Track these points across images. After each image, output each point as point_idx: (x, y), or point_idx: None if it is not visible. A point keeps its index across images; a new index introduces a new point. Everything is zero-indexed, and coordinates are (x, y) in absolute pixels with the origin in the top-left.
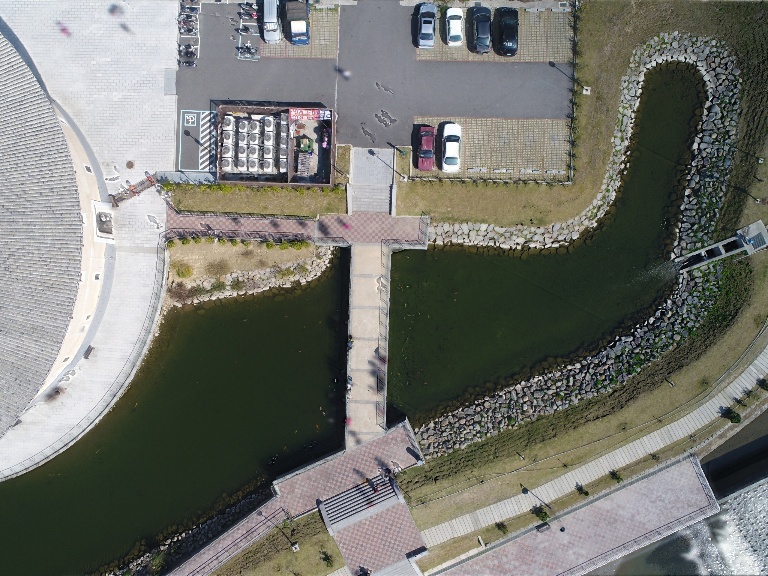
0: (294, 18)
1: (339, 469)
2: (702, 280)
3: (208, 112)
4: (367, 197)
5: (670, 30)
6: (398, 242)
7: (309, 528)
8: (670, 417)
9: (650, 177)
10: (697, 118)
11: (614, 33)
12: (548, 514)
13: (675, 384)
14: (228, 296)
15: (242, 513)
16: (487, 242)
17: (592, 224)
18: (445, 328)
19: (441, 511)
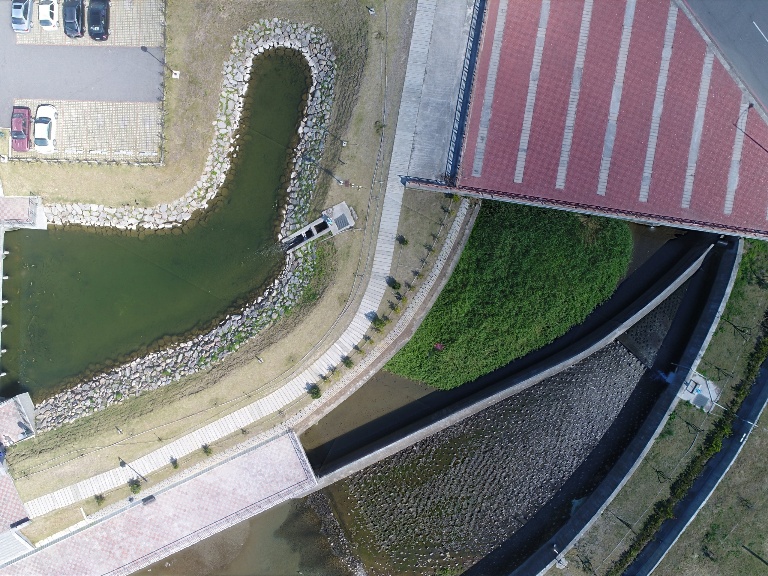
0: None
1: None
2: (302, 260)
3: None
4: None
5: (269, 17)
6: (9, 221)
7: None
8: (259, 393)
9: (263, 160)
10: (303, 103)
11: (206, 19)
12: (145, 487)
13: (264, 361)
14: None
15: None
16: (103, 222)
17: (202, 205)
18: (69, 306)
19: (43, 483)
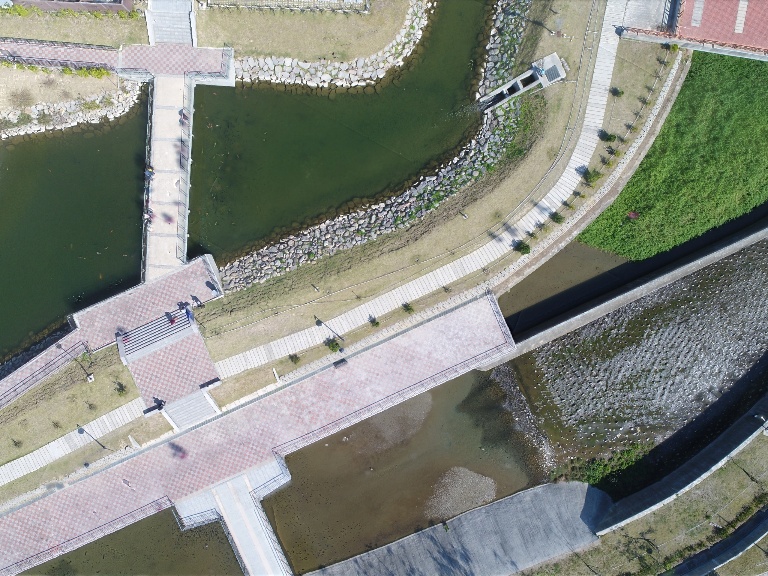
0: None
1: (139, 303)
2: (503, 118)
3: None
4: (168, 26)
5: None
6: (201, 74)
7: (106, 360)
8: (463, 250)
9: (459, 18)
10: None
11: None
12: (341, 346)
13: (469, 217)
14: (36, 131)
15: None
16: (294, 79)
17: (398, 62)
18: (254, 168)
19: (235, 342)
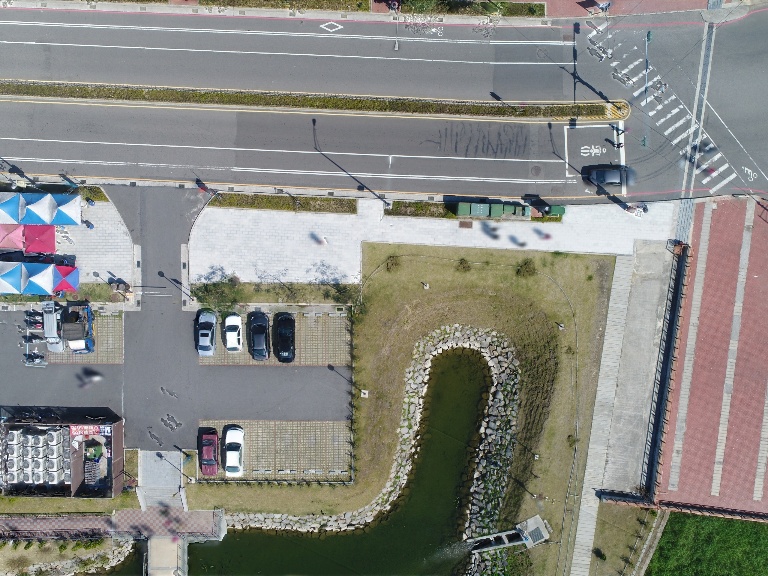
0: (70, 339)
1: None
2: (491, 564)
3: None
4: (158, 495)
5: (451, 323)
6: (193, 535)
7: None
8: None
9: (442, 457)
10: (484, 402)
11: (391, 334)
12: None
13: None
14: None
15: None
16: (284, 527)
17: (385, 508)
18: None
19: None
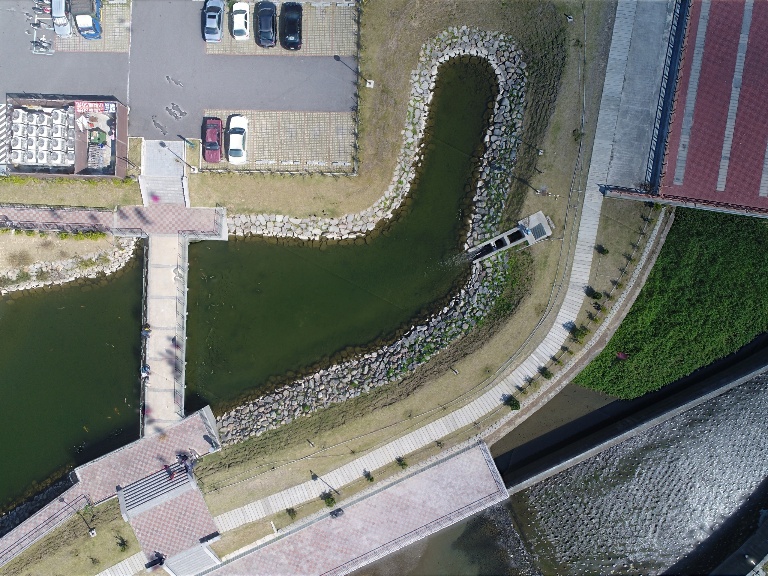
0: (78, 12)
1: (138, 456)
2: (492, 270)
3: (4, 105)
4: (161, 189)
5: (458, 24)
6: (194, 233)
7: (107, 514)
8: (454, 404)
9: (446, 169)
10: (489, 111)
11: (399, 27)
12: (337, 500)
13: (459, 372)
14: (35, 286)
15: (48, 500)
16: (285, 233)
17: (387, 215)
18: (248, 318)
19: (233, 497)
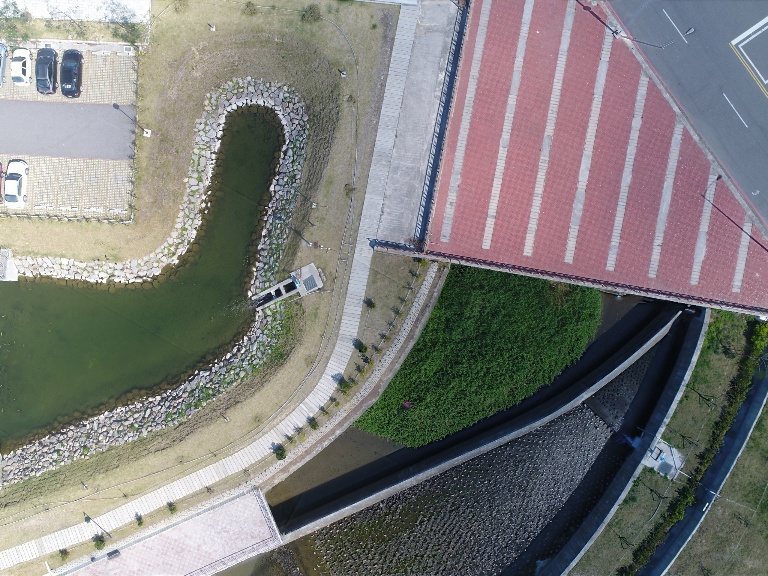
0: None
1: None
2: (271, 319)
3: None
4: None
5: (243, 75)
6: None
7: None
8: (225, 452)
9: (234, 216)
10: (275, 161)
11: (179, 77)
12: (109, 542)
13: (230, 420)
14: None
15: None
16: (73, 276)
17: (173, 261)
18: (39, 357)
19: (8, 537)
